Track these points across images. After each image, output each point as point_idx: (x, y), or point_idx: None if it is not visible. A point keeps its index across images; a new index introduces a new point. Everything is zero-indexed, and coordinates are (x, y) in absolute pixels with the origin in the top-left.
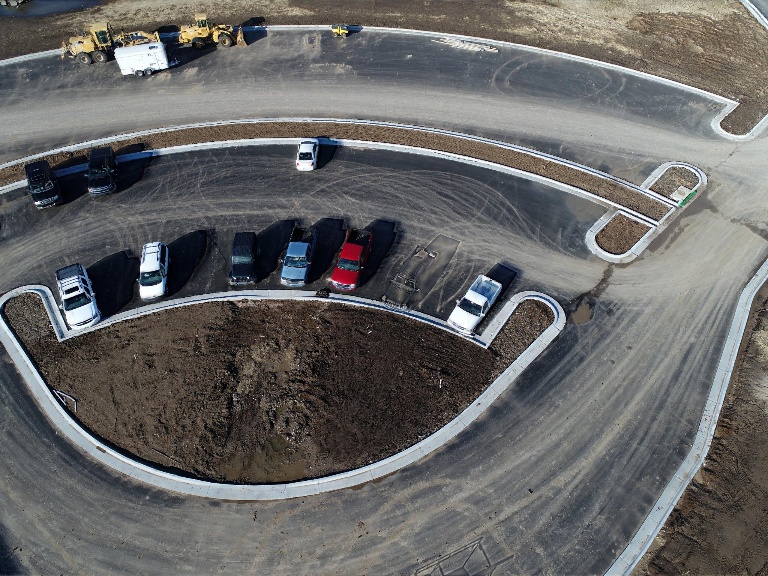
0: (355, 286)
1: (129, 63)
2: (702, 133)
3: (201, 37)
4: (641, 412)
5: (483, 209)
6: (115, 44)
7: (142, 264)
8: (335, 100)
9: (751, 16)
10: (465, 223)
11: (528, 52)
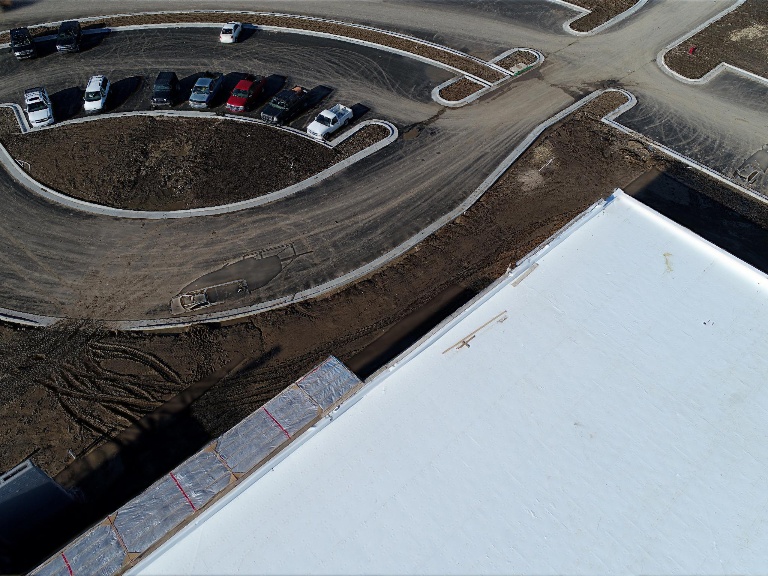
0: (243, 108)
1: None
2: (553, 30)
3: None
4: (432, 186)
5: (359, 71)
6: None
7: (88, 87)
8: (263, 0)
9: None
10: (342, 79)
11: None
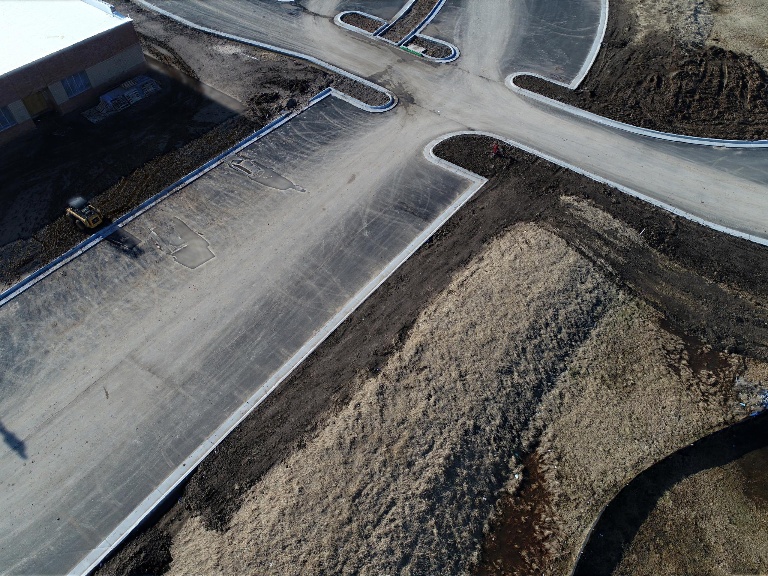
0: None
1: None
2: (509, 66)
3: None
4: (222, 16)
5: None
6: None
7: None
8: None
9: None
10: None
11: None
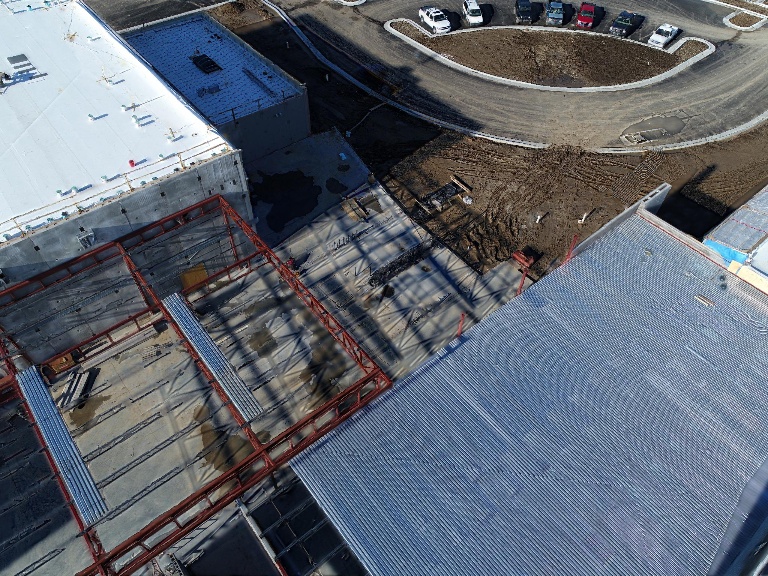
0: (591, 25)
1: None
2: None
3: None
4: (763, 80)
5: (656, 5)
6: None
7: (469, 6)
8: None
9: None
10: (647, 10)
11: None
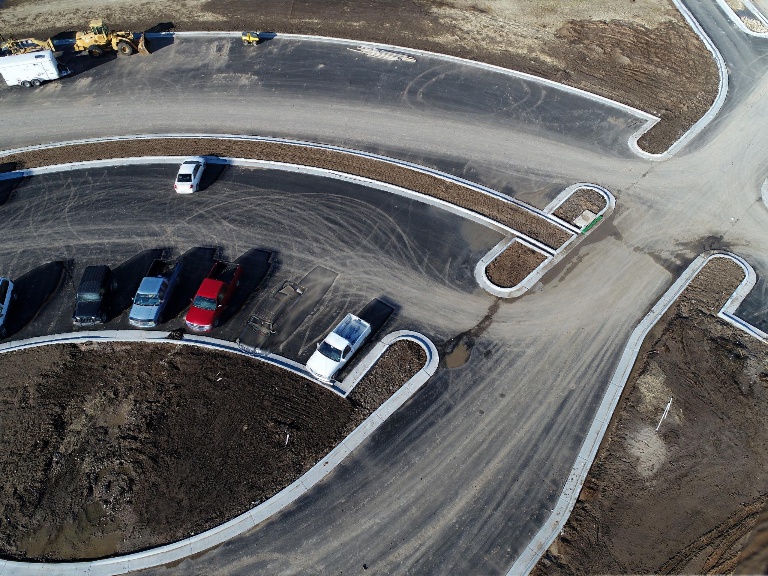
0: (210, 327)
1: (14, 73)
2: (617, 151)
3: (98, 45)
4: (503, 471)
5: (370, 236)
6: (5, 52)
7: None
8: (233, 114)
9: (686, 24)
10: (348, 252)
11: (447, 62)
